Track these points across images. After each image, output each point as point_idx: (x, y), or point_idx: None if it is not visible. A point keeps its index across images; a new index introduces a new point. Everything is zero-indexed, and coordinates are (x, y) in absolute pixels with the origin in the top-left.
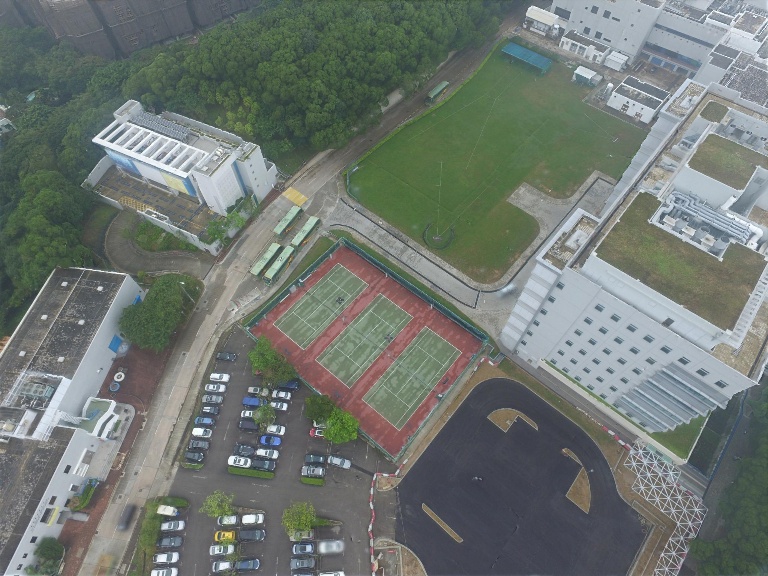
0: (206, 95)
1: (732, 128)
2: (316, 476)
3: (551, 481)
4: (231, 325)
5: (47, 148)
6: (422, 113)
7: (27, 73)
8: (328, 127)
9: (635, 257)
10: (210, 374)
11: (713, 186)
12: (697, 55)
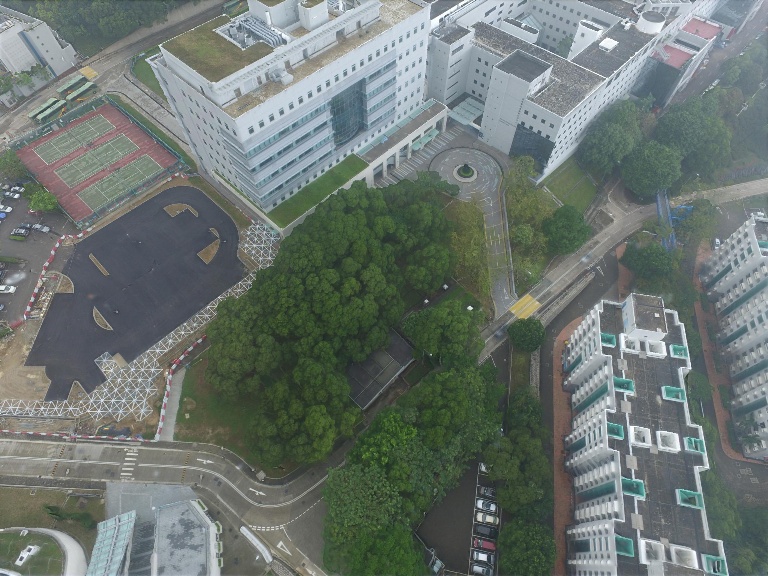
0: None
1: None
2: (20, 234)
3: (191, 246)
4: None
5: None
6: None
7: None
8: (112, 15)
9: (186, 47)
10: None
11: (260, 7)
12: None
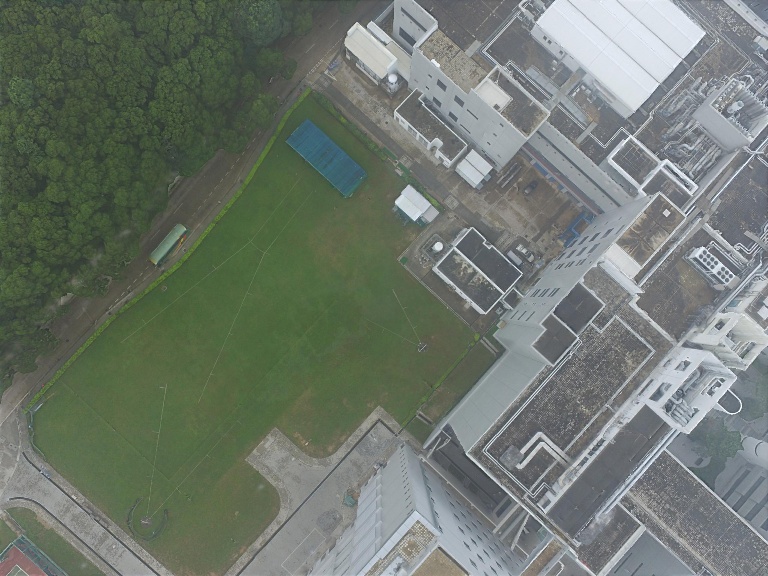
0: None
1: None
2: None
3: None
4: None
5: None
6: (146, 285)
7: None
8: None
9: None
10: None
11: None
12: (591, 194)
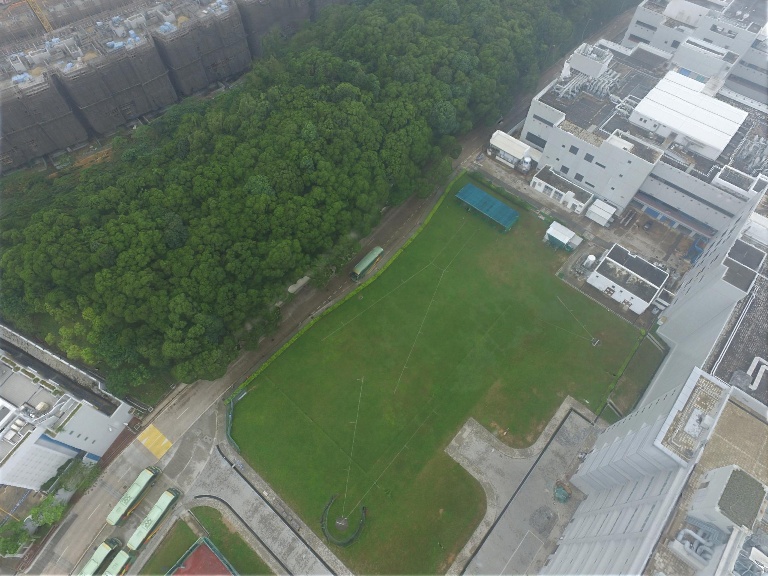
0: (32, 303)
1: None
2: None
3: None
4: None
5: None
6: (345, 294)
7: None
8: (196, 355)
9: None
10: None
11: None
12: (704, 217)
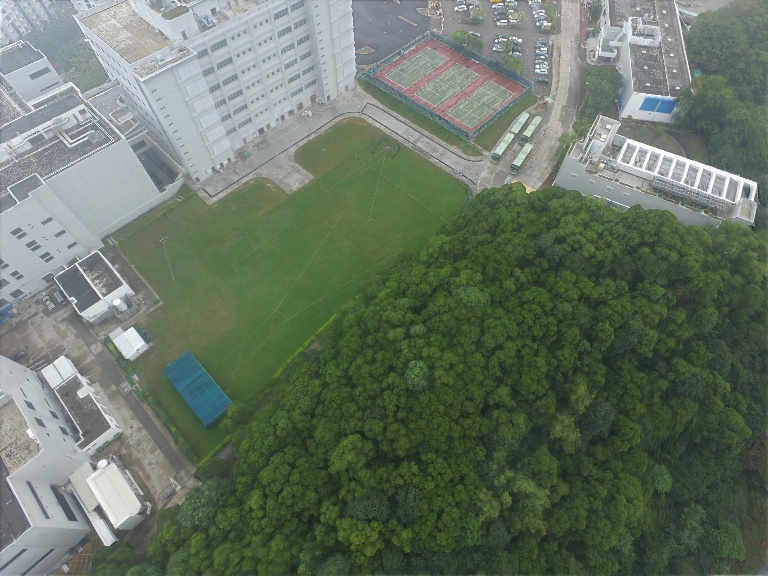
0: None
1: (175, 2)
2: None
3: None
4: None
5: None
6: None
7: None
8: None
9: None
10: None
11: None
12: None
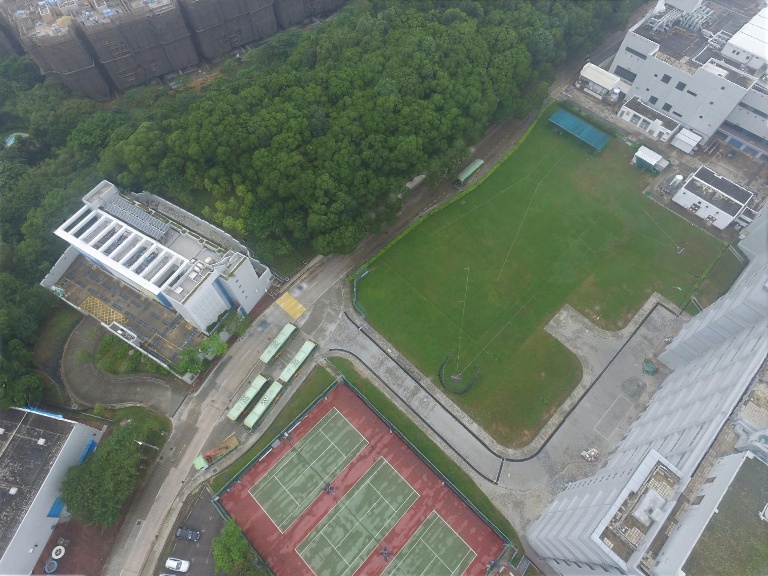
0: (193, 179)
1: None
2: None
3: None
4: (199, 485)
5: (9, 227)
6: (449, 199)
7: (8, 112)
8: (334, 229)
9: None
10: (166, 558)
11: None
12: None
